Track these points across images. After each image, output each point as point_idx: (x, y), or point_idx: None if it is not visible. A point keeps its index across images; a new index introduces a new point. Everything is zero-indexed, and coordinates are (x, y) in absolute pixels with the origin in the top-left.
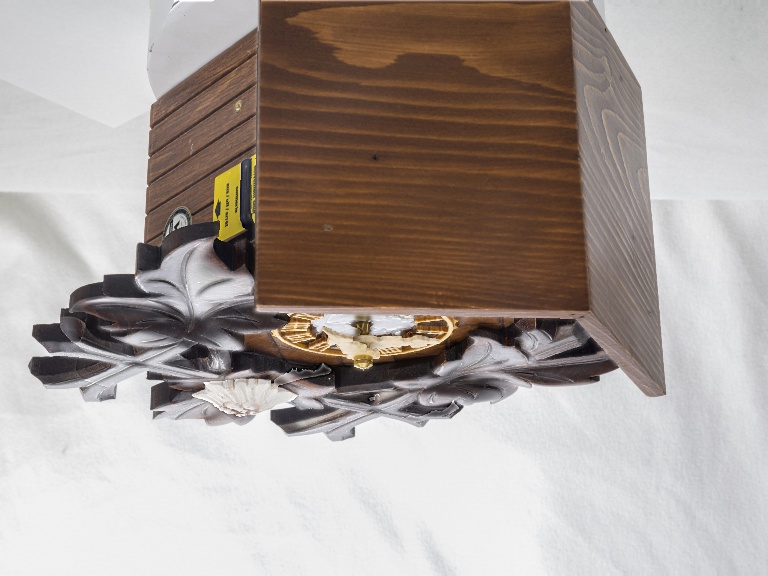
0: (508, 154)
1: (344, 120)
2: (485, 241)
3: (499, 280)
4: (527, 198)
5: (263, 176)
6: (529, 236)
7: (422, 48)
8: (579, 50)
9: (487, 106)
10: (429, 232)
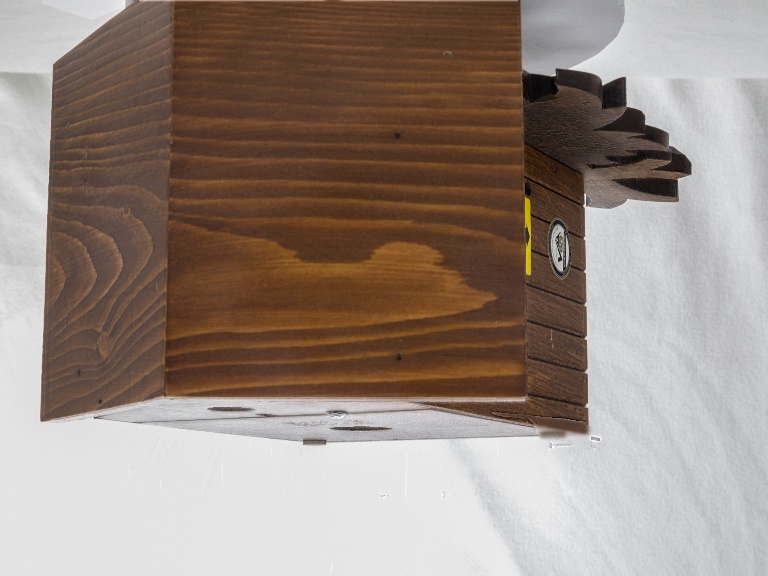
0: (251, 145)
1: (431, 177)
2: (282, 45)
3: (269, 3)
4: (233, 94)
5: (517, 110)
6: (234, 52)
7: (343, 270)
8: (156, 293)
9: (272, 201)
10: (341, 53)
